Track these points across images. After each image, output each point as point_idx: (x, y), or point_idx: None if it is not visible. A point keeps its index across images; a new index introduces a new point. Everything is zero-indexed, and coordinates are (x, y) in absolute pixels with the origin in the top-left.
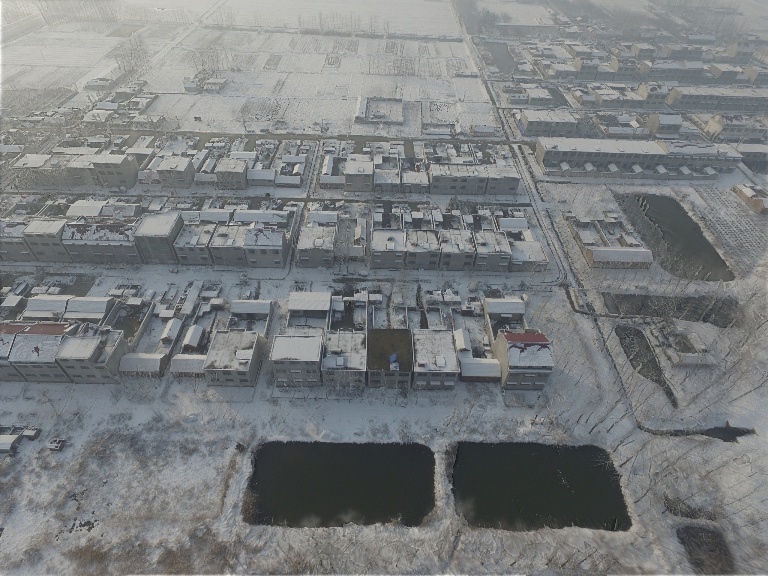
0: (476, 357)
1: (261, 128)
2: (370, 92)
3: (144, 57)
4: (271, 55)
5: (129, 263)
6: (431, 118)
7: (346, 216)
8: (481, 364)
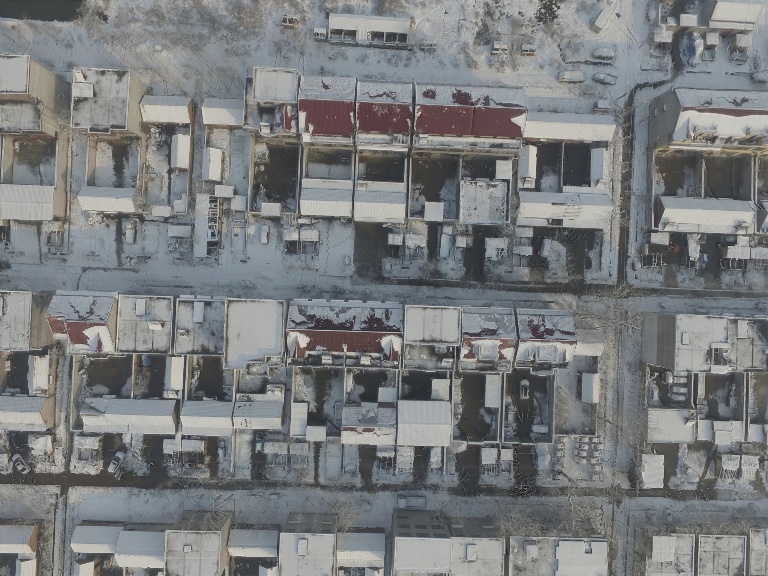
0: None
1: None
2: None
3: None
4: None
5: (315, 298)
6: None
7: None
8: None
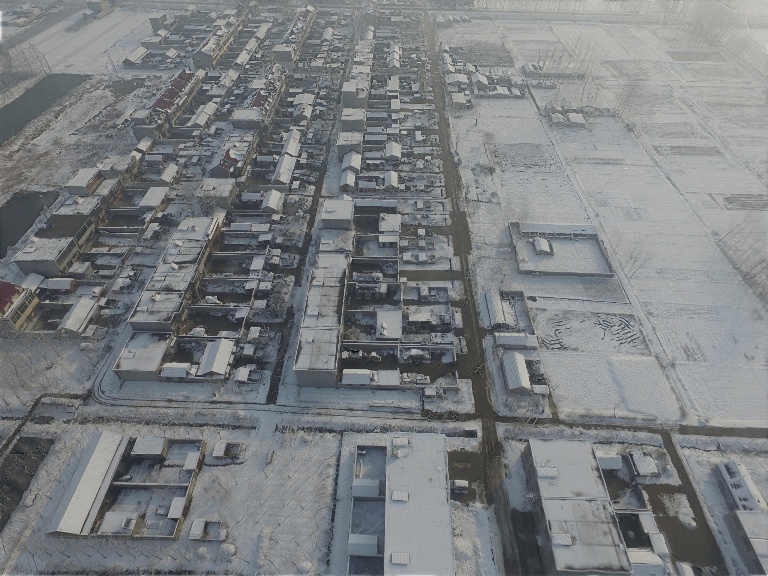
0: (48, 297)
1: (467, 158)
2: (633, 241)
3: (590, 69)
4: (713, 147)
5: None
6: (561, 311)
7: (274, 217)
8: (22, 285)
